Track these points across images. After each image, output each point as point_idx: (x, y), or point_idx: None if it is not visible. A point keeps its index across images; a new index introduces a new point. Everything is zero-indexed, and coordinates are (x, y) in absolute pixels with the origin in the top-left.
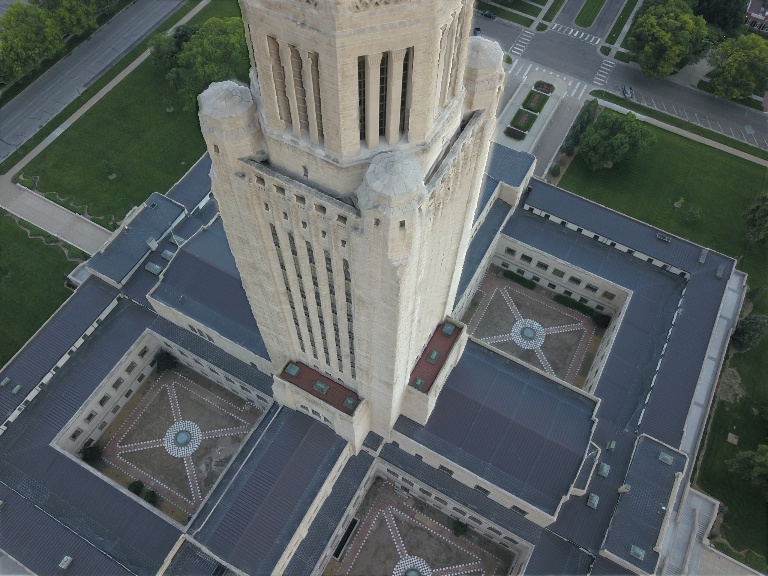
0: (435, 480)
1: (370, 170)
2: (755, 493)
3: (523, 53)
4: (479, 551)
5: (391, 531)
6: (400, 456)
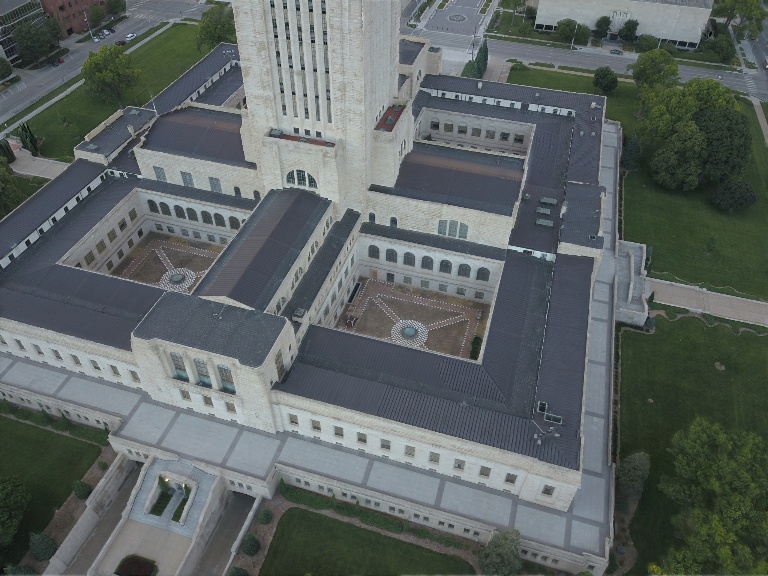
0: None
1: None
2: None
3: None
4: None
5: None
6: None
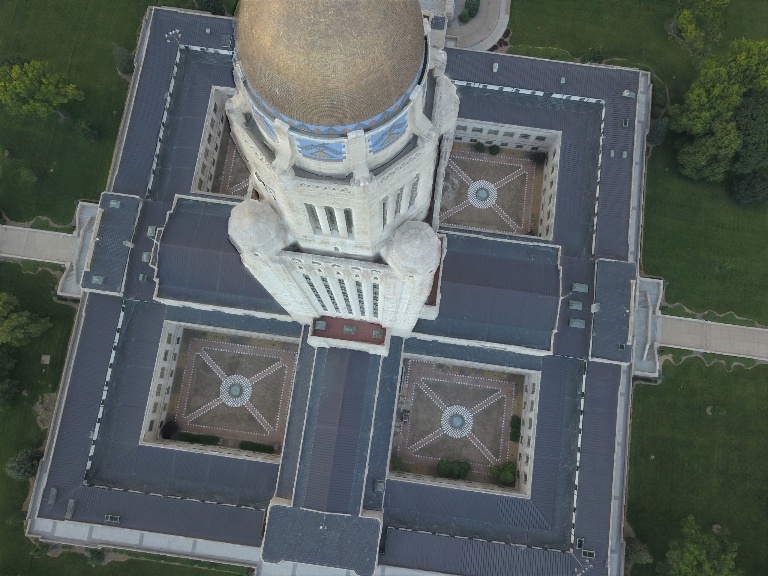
0: None
1: None
2: None
3: None
4: None
5: None
6: None
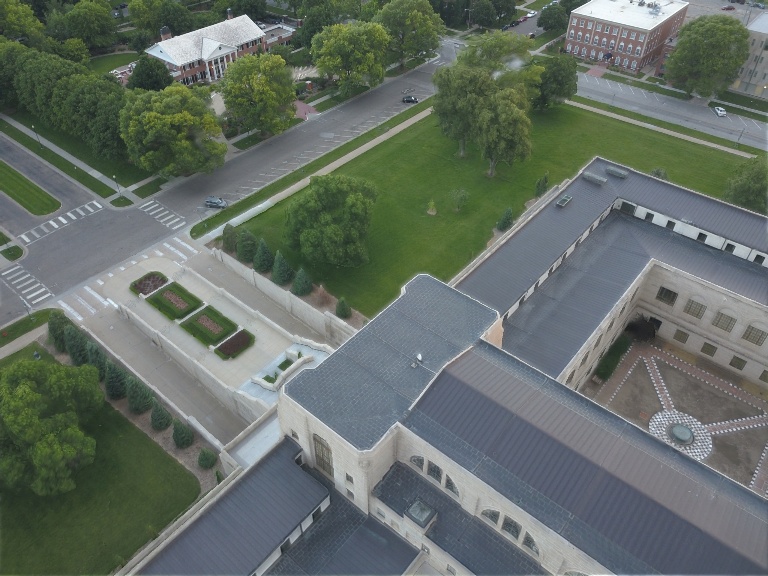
0: None
1: None
2: None
3: (51, 290)
4: None
5: None
6: None
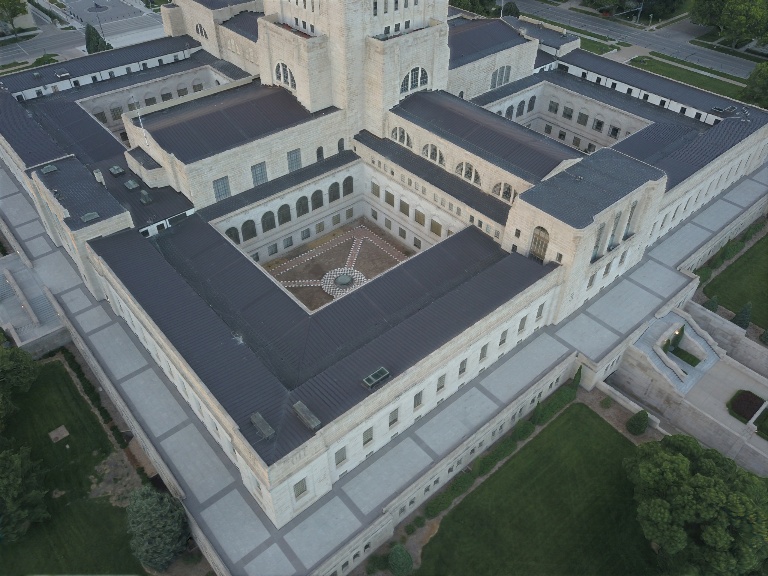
0: None
1: None
2: None
3: None
4: None
5: None
6: None
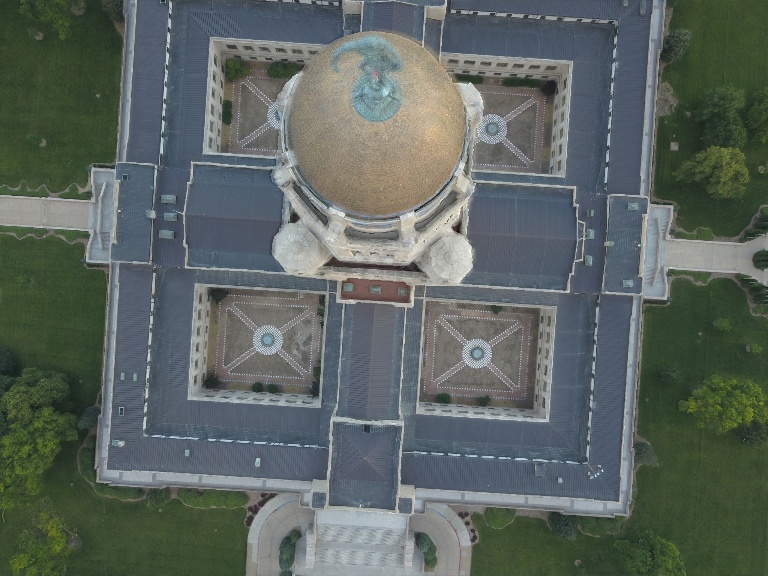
0: (472, 294)
1: (434, 263)
2: (697, 183)
3: None
4: (515, 316)
5: (449, 331)
6: (440, 289)
